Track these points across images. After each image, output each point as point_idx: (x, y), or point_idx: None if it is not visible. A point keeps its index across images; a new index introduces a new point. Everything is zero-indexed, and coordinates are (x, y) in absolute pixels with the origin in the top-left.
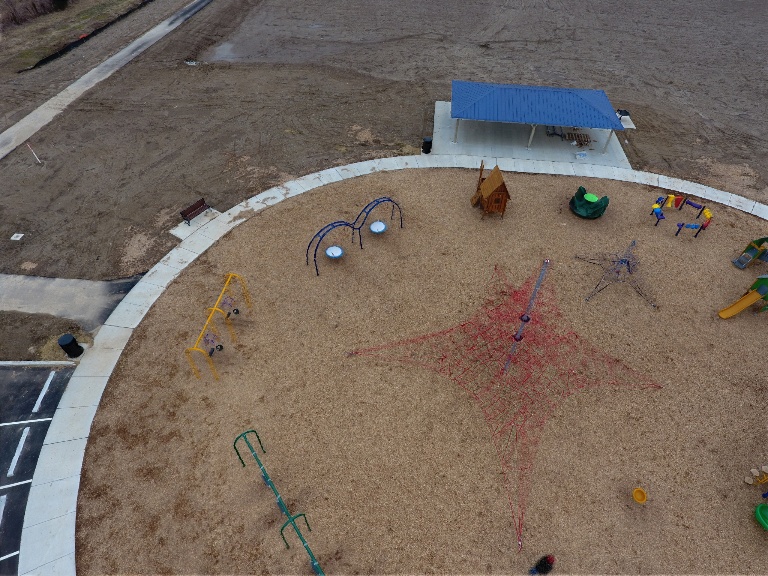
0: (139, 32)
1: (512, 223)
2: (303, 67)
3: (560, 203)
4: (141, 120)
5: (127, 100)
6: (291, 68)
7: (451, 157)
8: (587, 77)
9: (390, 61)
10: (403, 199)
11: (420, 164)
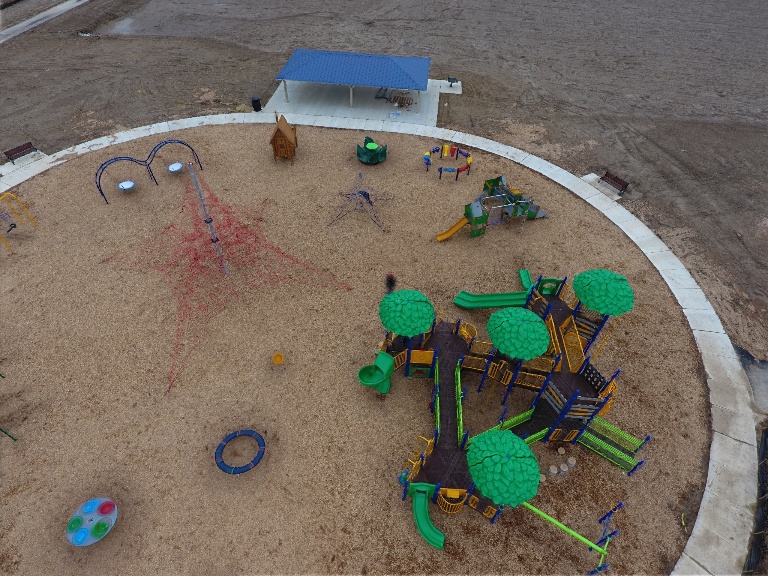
0: (45, 7)
1: (300, 167)
2: (184, 39)
3: (354, 152)
4: (10, 80)
5: (6, 64)
6: (171, 39)
7: None
8: (448, 51)
9: (272, 35)
10: (215, 147)
11: (246, 120)
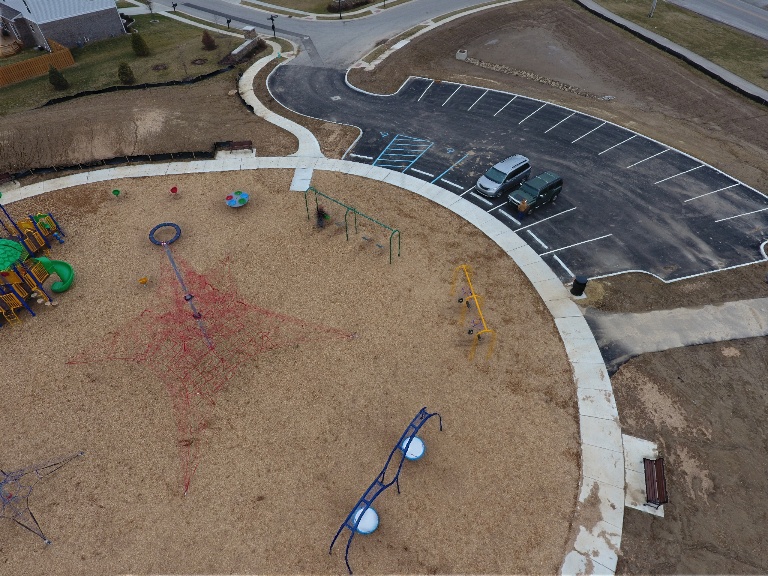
0: None
1: None
2: None
3: None
4: None
5: None
6: None
7: None
8: None
9: None
10: None
11: None
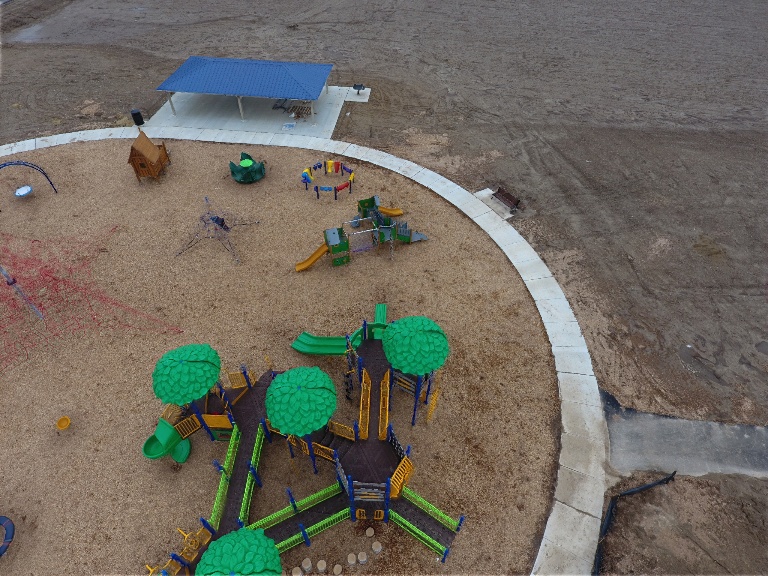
0: None
1: (167, 188)
2: (85, 46)
3: None
4: None
5: None
6: (70, 47)
7: (160, 128)
8: (368, 56)
9: (185, 41)
10: (79, 167)
11: (123, 135)
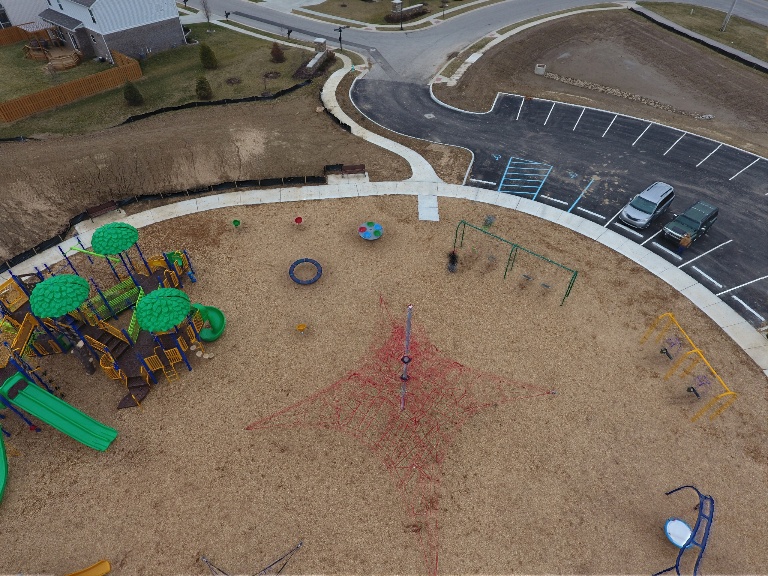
0: None
1: None
2: None
3: None
4: None
5: None
6: None
7: None
8: None
9: None
10: None
11: None
